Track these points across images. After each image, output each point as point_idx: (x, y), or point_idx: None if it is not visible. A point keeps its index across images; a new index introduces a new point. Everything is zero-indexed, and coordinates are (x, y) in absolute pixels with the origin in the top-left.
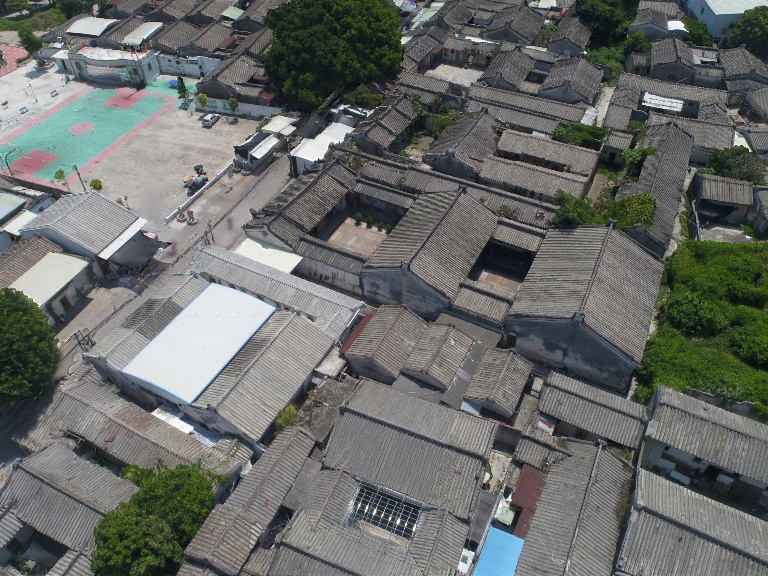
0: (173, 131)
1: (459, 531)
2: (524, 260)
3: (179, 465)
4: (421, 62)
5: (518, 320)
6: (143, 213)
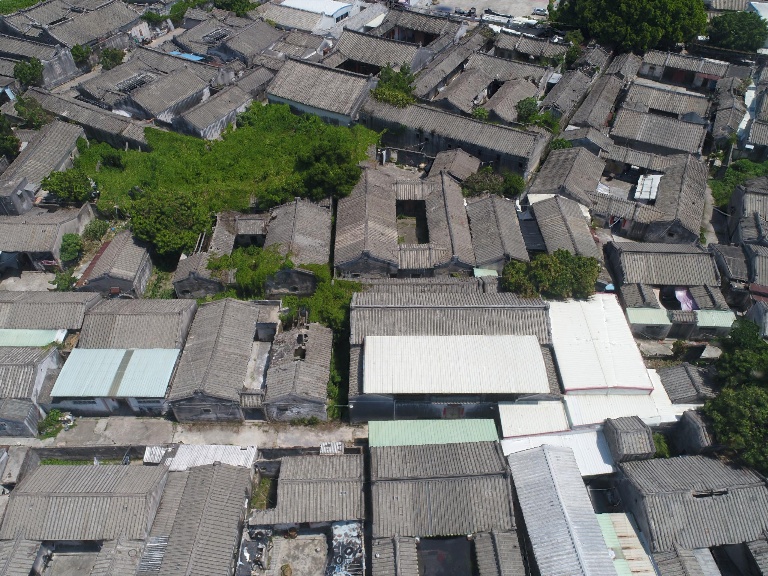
0: (525, 6)
1: (205, 51)
2: None
3: None
4: (683, 75)
5: None
6: (434, 7)
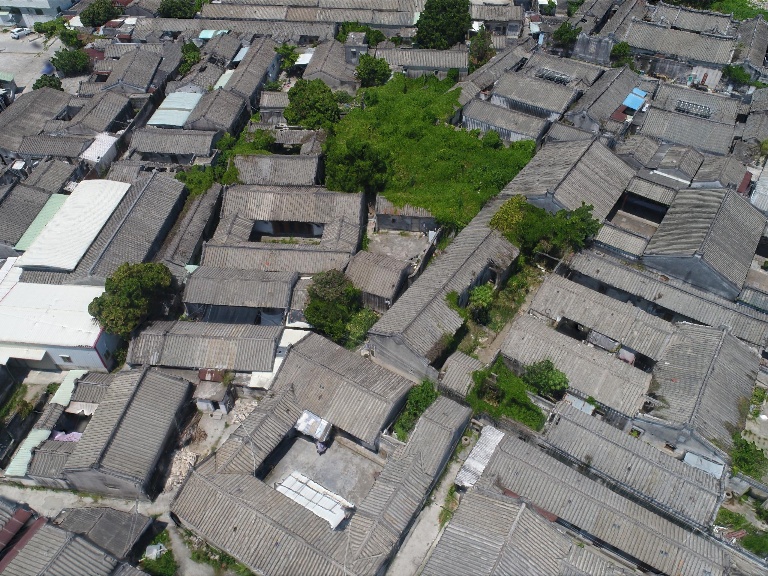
0: None
1: None
2: None
3: None
4: None
5: None
6: None
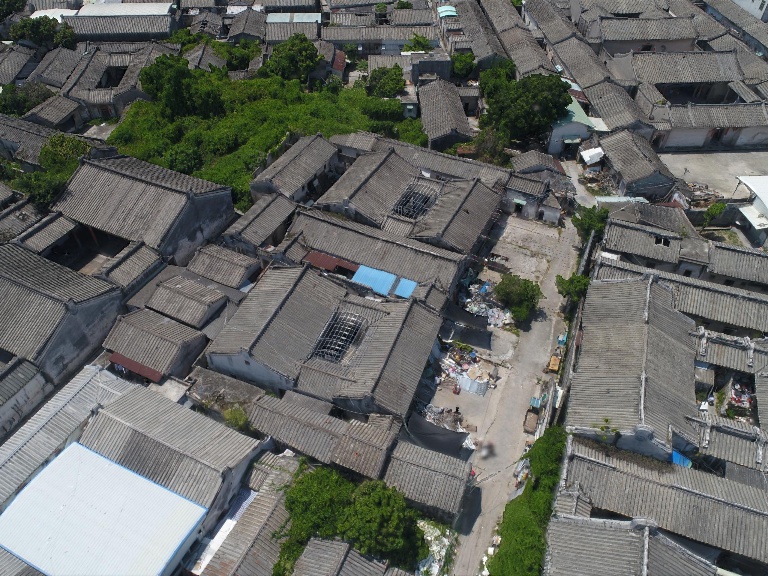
0: None
1: (354, 298)
2: (62, 253)
3: (288, 500)
4: None
5: (166, 242)
6: None
